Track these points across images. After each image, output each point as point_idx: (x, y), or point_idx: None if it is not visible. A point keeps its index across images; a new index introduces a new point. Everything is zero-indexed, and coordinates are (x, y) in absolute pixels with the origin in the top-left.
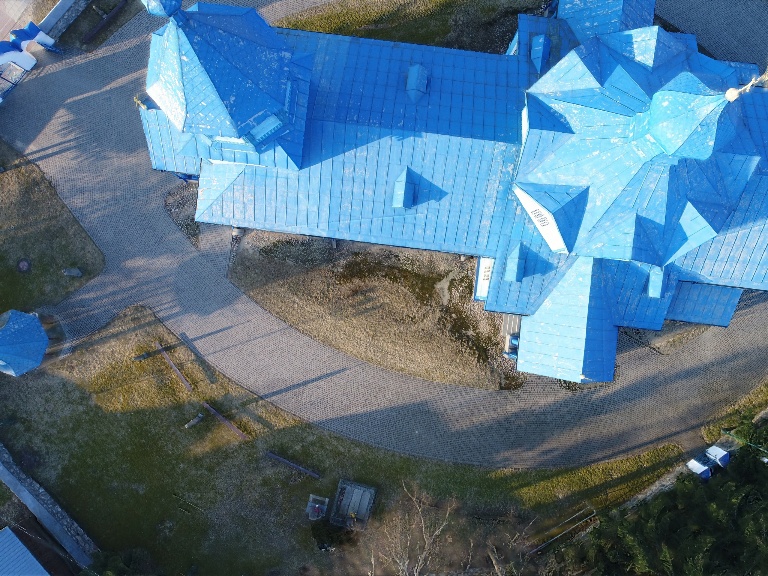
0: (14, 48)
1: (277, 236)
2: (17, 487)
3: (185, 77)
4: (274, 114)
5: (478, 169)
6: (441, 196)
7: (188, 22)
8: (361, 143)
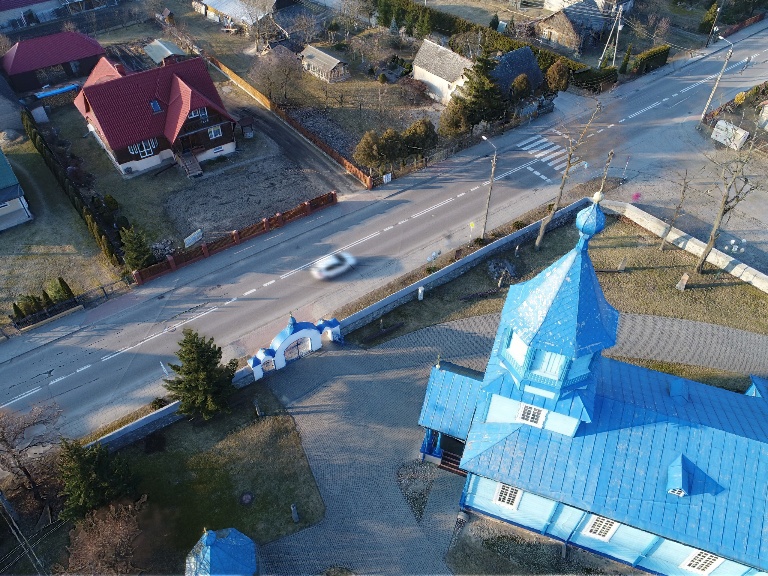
0: (318, 329)
1: (503, 530)
2: None
3: (558, 296)
4: (592, 359)
5: (756, 469)
6: (717, 490)
7: (586, 252)
8: (637, 423)
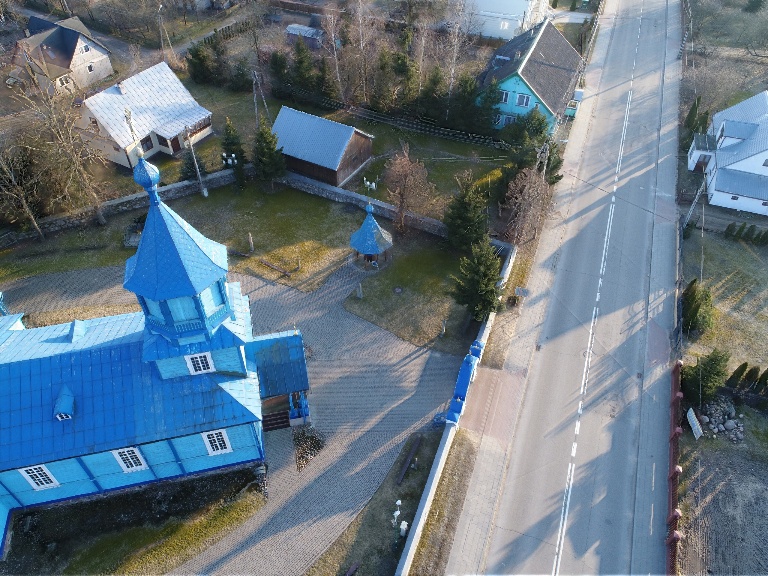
0: (456, 395)
1: None
2: (346, 193)
3: None
4: None
5: None
6: None
7: None
8: None
